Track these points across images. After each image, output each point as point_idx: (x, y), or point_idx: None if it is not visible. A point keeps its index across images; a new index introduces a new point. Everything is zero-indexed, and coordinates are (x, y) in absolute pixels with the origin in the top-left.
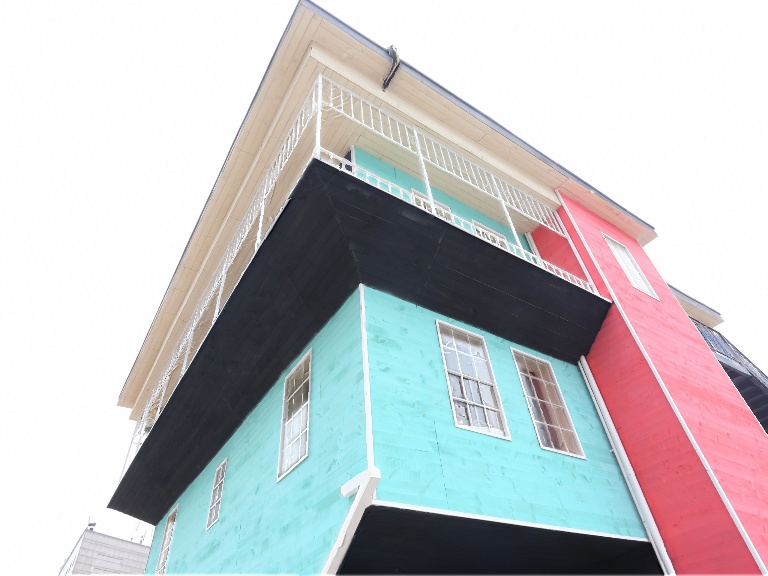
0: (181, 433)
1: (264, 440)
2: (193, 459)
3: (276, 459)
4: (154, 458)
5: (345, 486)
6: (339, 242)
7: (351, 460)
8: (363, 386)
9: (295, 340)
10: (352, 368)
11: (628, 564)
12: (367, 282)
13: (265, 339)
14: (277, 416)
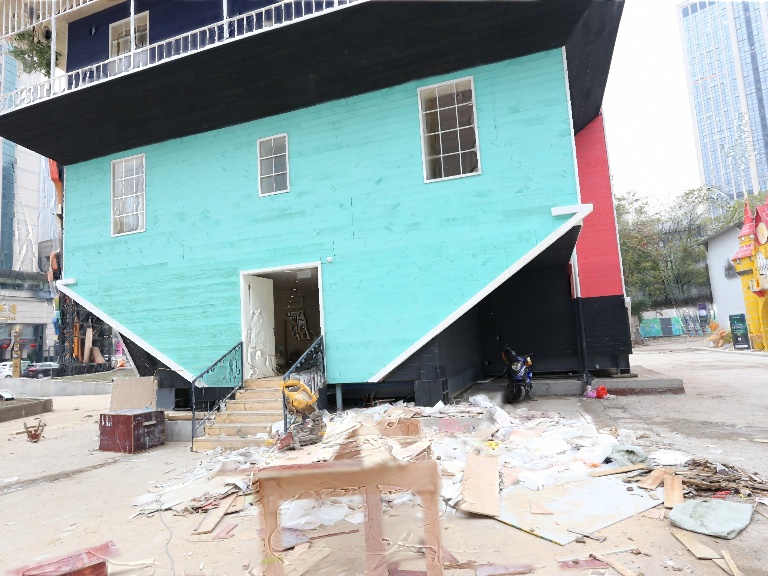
0: (207, 85)
1: (382, 138)
2: (203, 116)
3: (416, 162)
4: (131, 96)
5: (558, 209)
6: (582, 3)
7: (554, 192)
8: (569, 142)
9: (455, 60)
10: (552, 122)
11: (548, 272)
12: (566, 47)
13: (422, 44)
14: (407, 122)
